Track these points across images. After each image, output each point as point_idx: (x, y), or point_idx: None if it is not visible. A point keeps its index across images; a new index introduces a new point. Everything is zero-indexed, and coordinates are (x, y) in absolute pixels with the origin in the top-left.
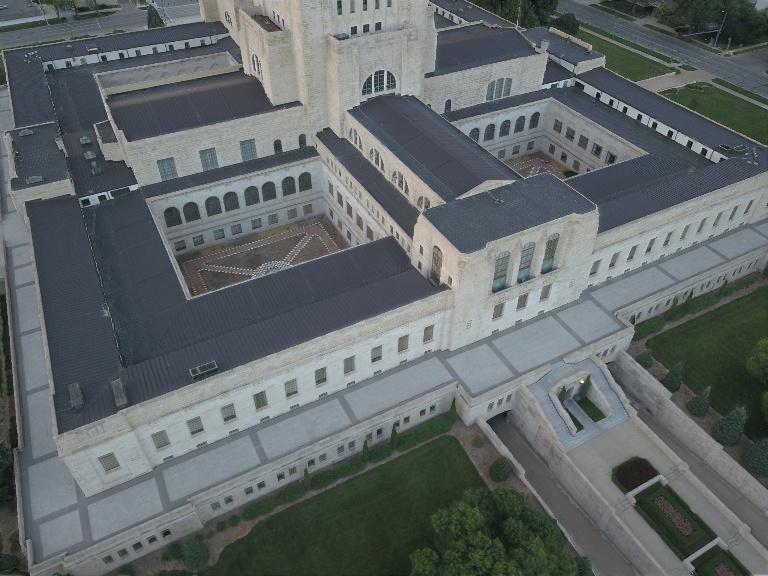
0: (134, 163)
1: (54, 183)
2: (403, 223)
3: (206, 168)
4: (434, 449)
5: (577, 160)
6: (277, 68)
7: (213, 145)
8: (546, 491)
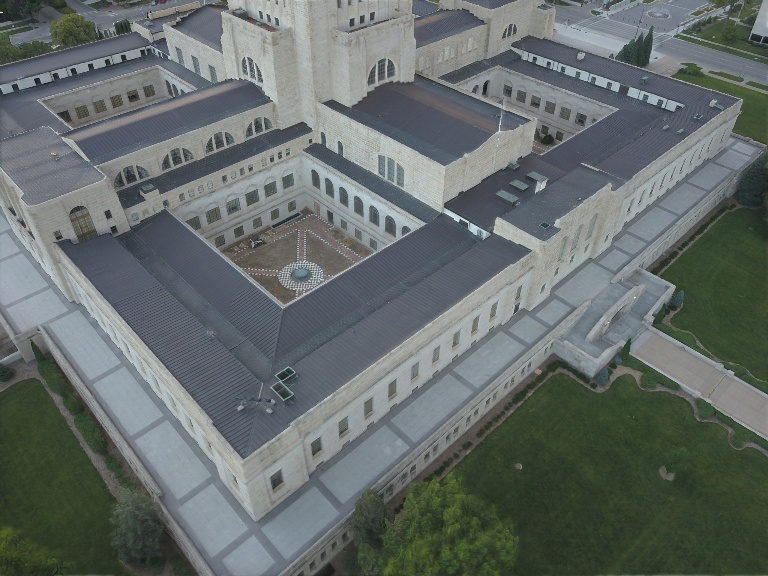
0: (167, 40)
1: (144, 28)
2: None
3: (197, 72)
4: None
5: None
6: None
7: (197, 56)
8: None
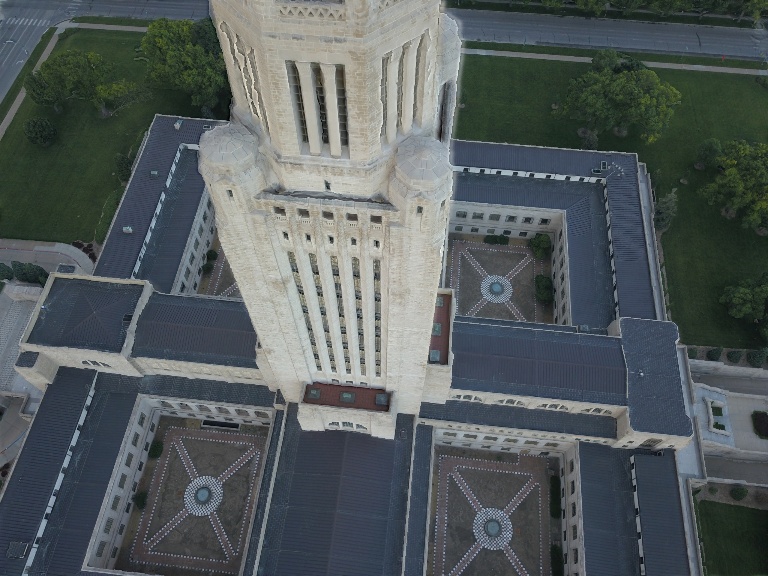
0: None
1: None
2: (587, 431)
3: None
4: (706, 518)
5: (491, 229)
6: (395, 420)
7: None
8: (735, 470)
